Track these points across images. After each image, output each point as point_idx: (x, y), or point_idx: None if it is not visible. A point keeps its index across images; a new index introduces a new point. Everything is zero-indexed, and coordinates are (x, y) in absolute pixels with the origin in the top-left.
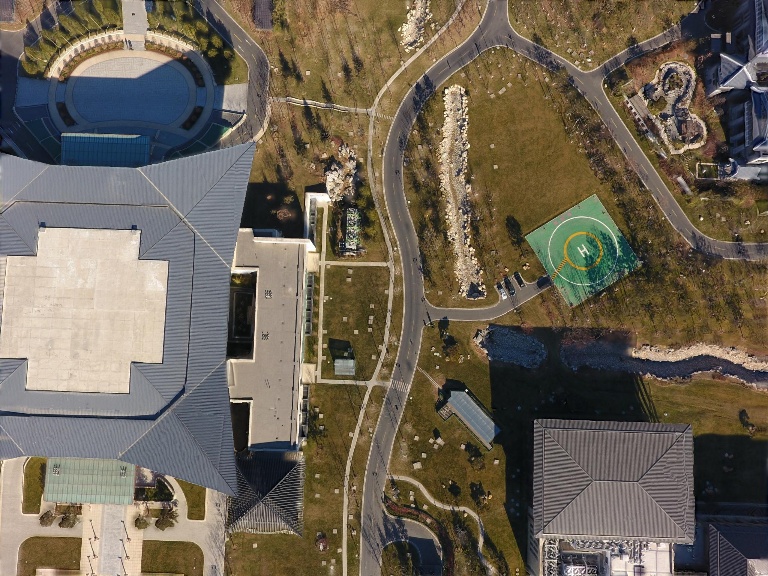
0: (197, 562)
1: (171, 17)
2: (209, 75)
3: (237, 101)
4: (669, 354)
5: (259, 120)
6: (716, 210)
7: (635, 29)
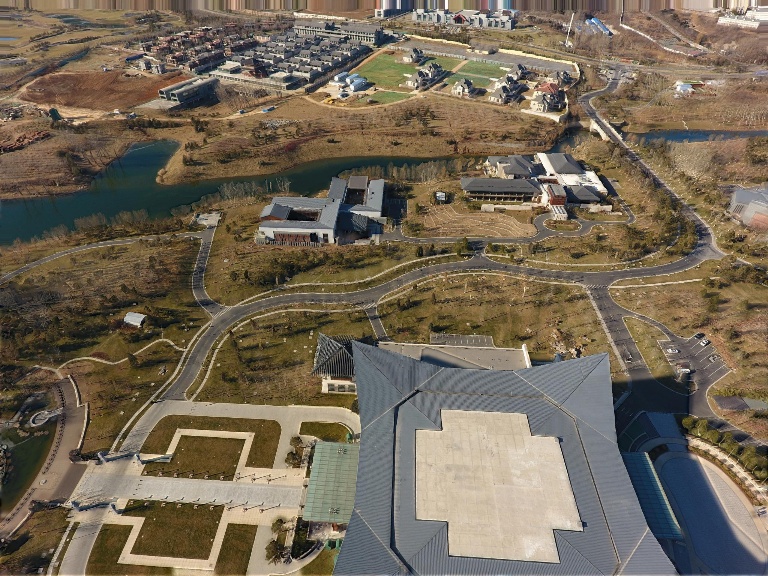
0: None
1: None
2: None
3: None
4: None
5: None
6: None
7: None
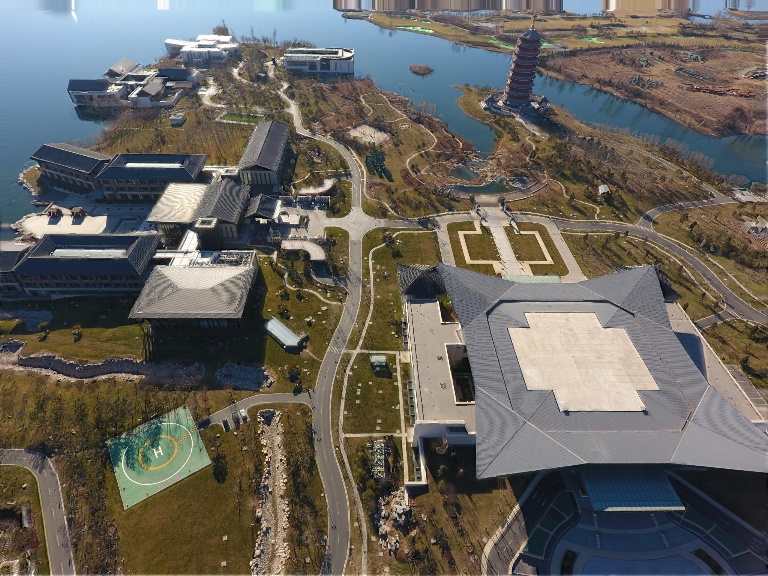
0: None
1: None
2: None
3: None
4: (115, 377)
5: (493, 568)
6: (3, 496)
7: None
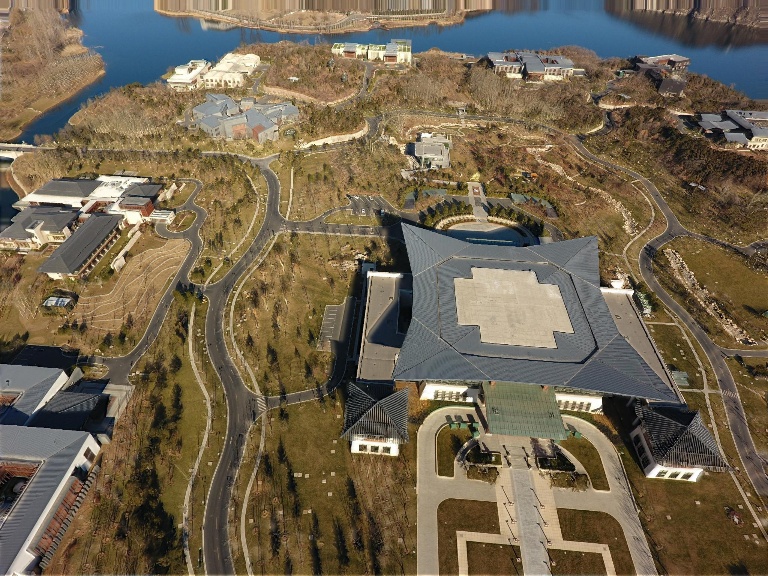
0: (617, 532)
1: None
2: (528, 233)
3: None
4: None
5: None
6: None
7: (758, 233)
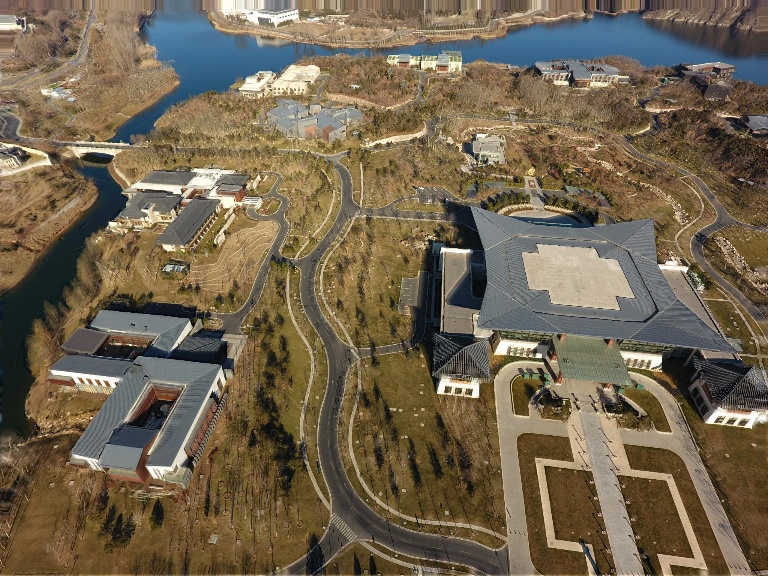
0: (679, 465)
1: None
2: None
3: None
4: None
5: None
6: None
7: None
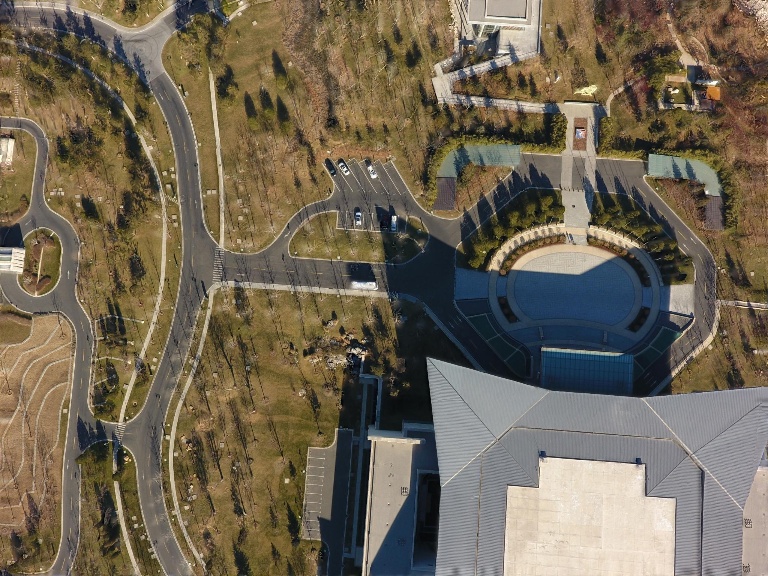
0: None
1: (617, 213)
2: (654, 274)
3: (684, 303)
4: None
5: (708, 324)
6: None
7: None
